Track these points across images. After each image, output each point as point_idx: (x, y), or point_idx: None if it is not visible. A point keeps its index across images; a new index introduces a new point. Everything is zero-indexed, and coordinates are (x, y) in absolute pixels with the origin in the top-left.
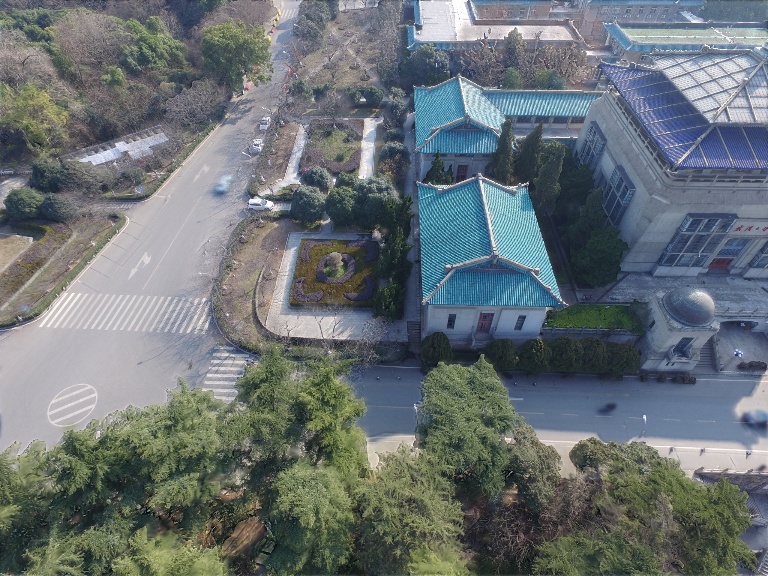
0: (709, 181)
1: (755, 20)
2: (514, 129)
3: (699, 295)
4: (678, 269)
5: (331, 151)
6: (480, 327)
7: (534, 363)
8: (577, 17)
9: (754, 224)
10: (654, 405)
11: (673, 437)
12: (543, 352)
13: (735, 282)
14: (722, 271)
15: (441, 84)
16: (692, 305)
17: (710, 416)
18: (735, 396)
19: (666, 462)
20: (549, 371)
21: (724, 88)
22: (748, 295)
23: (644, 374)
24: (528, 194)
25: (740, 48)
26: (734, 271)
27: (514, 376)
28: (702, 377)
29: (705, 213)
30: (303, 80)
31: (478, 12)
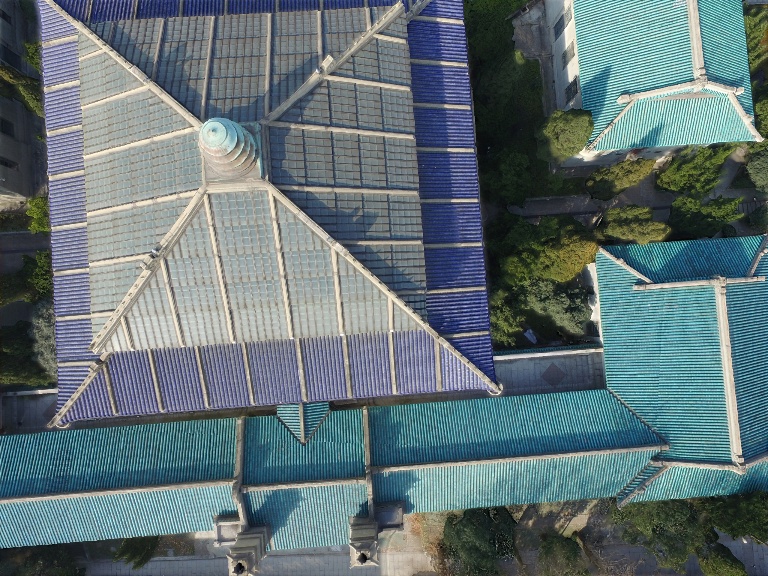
0: None
1: None
2: (566, 390)
3: None
4: None
5: None
6: None
7: None
8: None
9: None
10: None
11: None
12: None
13: None
14: None
15: (763, 458)
16: None
17: None
18: None
19: None
20: None
21: (355, 87)
22: None
23: None
24: None
25: None
26: None
27: None
28: None
29: None
30: None
31: None
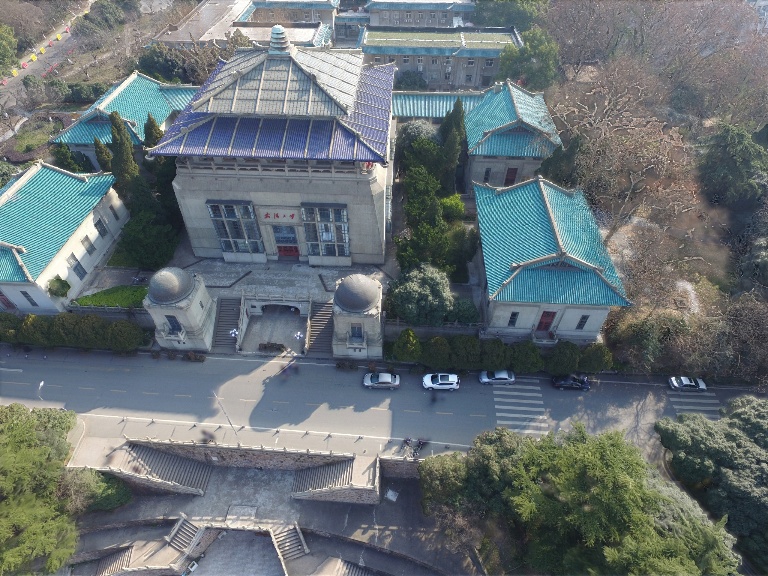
0: (210, 168)
1: (506, 25)
2: None
3: (162, 274)
4: (242, 255)
5: (29, 142)
6: (7, 303)
7: (26, 336)
8: (365, 21)
9: (277, 211)
10: (145, 380)
11: (137, 409)
12: (30, 325)
13: (298, 269)
14: (293, 259)
15: (123, 80)
16: (153, 283)
17: (189, 391)
18: (232, 374)
19: (23, 423)
20: (50, 345)
21: None
22: (299, 281)
23: (152, 351)
24: (112, 181)
25: (463, 51)
26: (302, 259)
27: (33, 350)
28: (217, 356)
29: (222, 199)
30: (33, 76)
31: (265, 15)
